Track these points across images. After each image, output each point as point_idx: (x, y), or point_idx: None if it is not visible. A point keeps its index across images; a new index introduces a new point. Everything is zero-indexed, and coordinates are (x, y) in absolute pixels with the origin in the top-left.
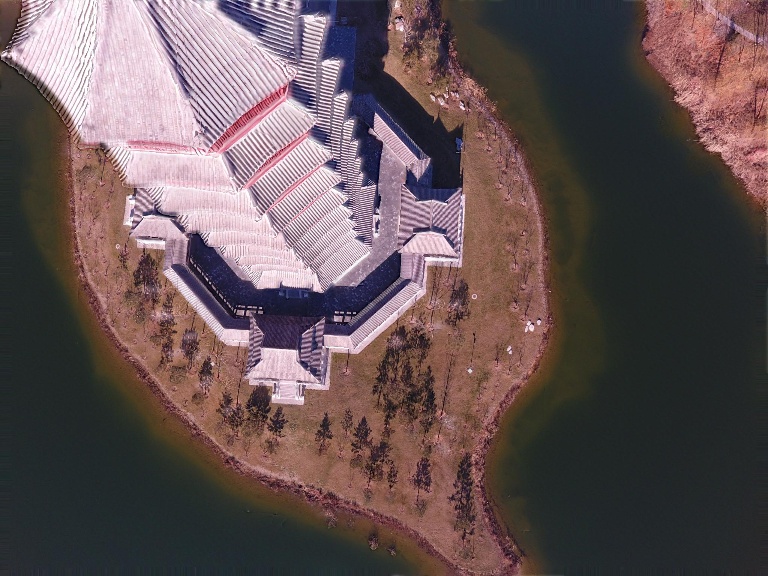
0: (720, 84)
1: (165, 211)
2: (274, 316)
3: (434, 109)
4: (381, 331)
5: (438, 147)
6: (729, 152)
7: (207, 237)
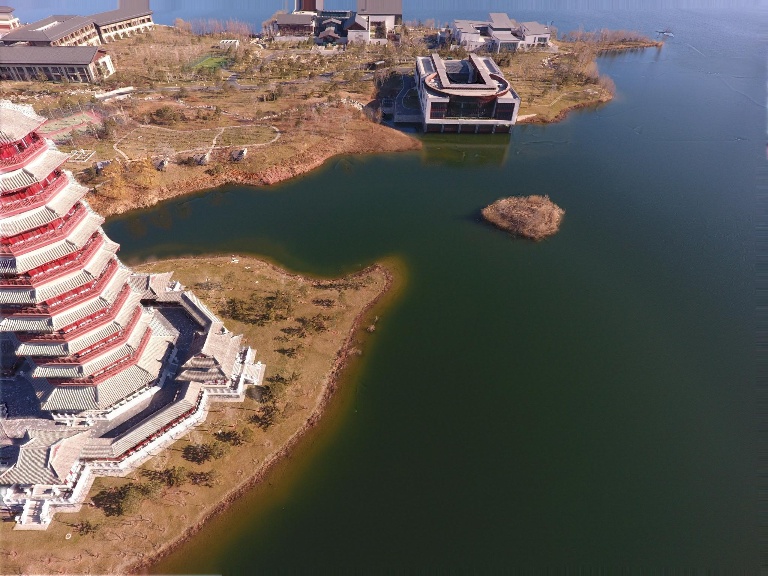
0: (119, 198)
1: (62, 213)
2: None
3: None
4: None
5: None
6: (159, 198)
7: (90, 276)
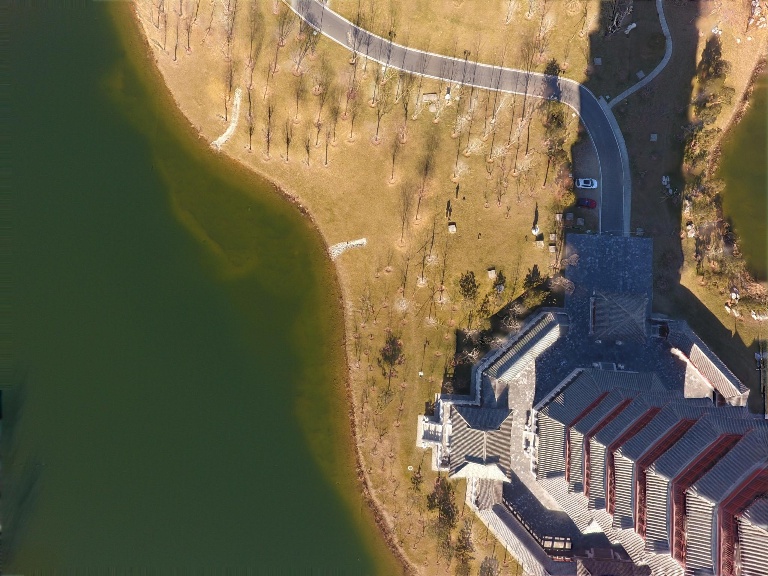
0: None
1: None
2: (602, 563)
3: (731, 322)
4: None
5: (738, 364)
6: None
7: None
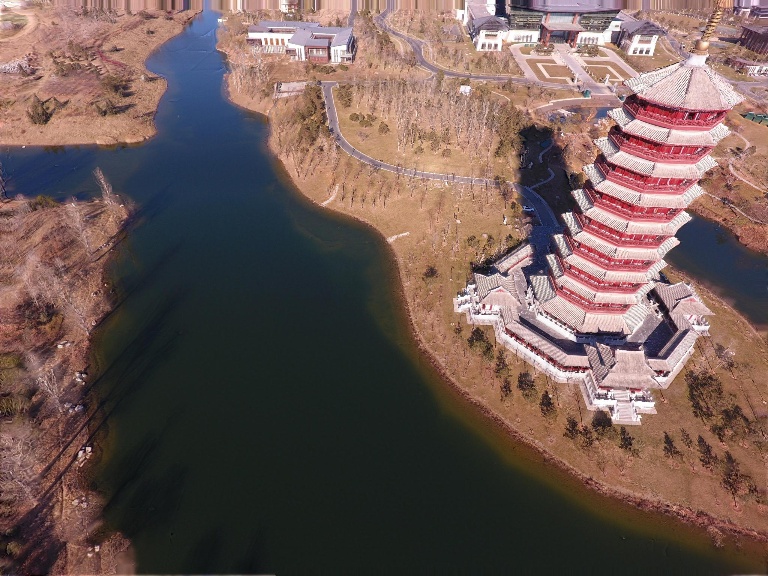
0: None
1: (656, 174)
2: None
3: None
4: (676, 374)
5: None
6: None
7: (625, 229)
